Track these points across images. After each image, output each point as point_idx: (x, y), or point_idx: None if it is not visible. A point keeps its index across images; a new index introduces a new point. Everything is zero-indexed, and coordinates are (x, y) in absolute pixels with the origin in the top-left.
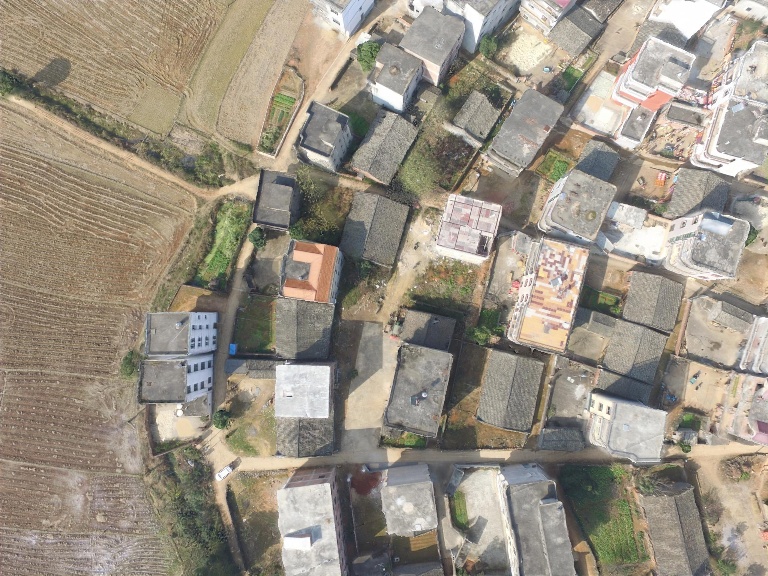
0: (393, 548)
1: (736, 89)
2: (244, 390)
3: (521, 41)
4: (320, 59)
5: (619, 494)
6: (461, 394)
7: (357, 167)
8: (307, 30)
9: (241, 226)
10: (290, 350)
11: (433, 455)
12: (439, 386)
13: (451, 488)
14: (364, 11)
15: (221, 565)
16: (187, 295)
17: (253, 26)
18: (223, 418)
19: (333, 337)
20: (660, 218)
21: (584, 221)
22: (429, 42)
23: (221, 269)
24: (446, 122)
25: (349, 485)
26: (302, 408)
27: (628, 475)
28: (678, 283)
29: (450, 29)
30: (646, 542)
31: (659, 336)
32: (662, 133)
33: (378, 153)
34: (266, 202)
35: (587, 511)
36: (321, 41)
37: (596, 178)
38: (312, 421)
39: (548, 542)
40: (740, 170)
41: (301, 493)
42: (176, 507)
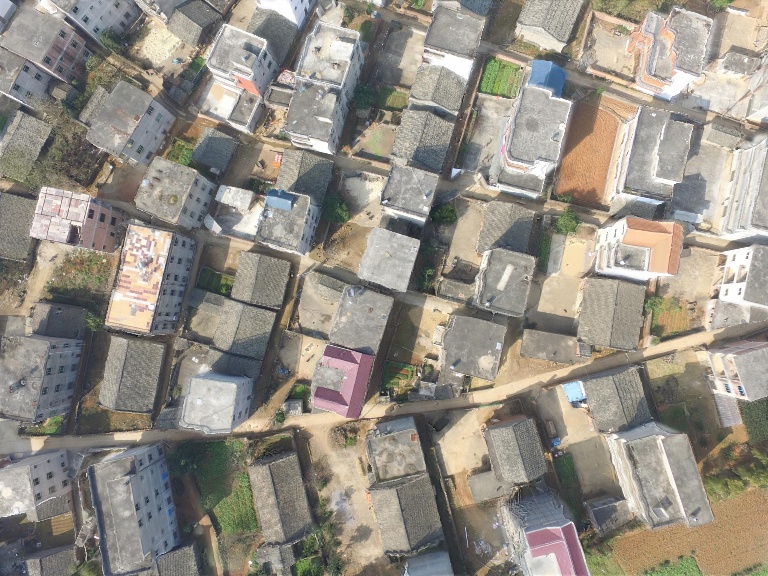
0: (36, 534)
1: (302, 70)
2: None
3: (153, 35)
4: None
5: (240, 467)
6: (95, 380)
7: None
8: None
9: None
10: None
11: (73, 441)
12: (37, 373)
13: (72, 471)
14: (1, 14)
15: None
16: None
17: None
18: None
19: None
20: None
21: (166, 205)
22: (28, 41)
23: None
24: (70, 117)
25: None
26: None
27: (246, 448)
28: (282, 260)
29: (48, 27)
30: None
31: (264, 312)
32: (279, 116)
33: (6, 151)
34: None
35: (210, 485)
36: None
37: (176, 163)
38: None
39: (116, 516)
40: (326, 148)
41: None
42: None
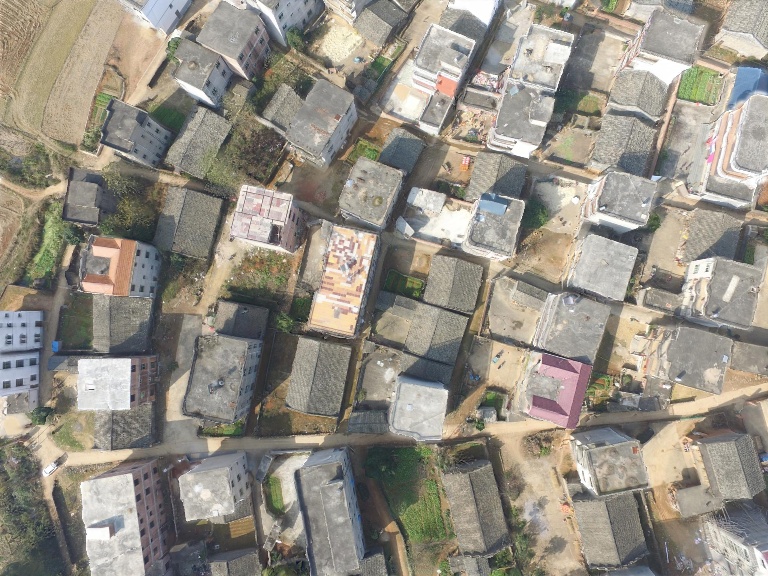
0: (213, 536)
1: (513, 72)
2: (69, 386)
3: (333, 33)
4: (140, 57)
5: (427, 474)
6: (276, 382)
7: (170, 162)
8: (126, 29)
9: (65, 225)
10: (105, 345)
11: (251, 443)
12: (235, 374)
13: (260, 474)
14: (179, 8)
15: (41, 559)
16: (13, 295)
17: (77, 27)
18: (40, 414)
19: (154, 331)
20: (462, 202)
21: (371, 207)
22: (224, 36)
23: (47, 268)
24: (254, 115)
25: (169, 475)
26: (104, 401)
27: (435, 455)
28: (476, 265)
29: (245, 23)
30: (451, 520)
31: (458, 317)
32: (466, 118)
33: (189, 148)
34: (72, 199)
35: (396, 492)
36: (140, 39)
37: (382, 164)
38: (127, 414)
39: (329, 522)
40: (528, 151)
41: (104, 484)
42: (4, 504)
